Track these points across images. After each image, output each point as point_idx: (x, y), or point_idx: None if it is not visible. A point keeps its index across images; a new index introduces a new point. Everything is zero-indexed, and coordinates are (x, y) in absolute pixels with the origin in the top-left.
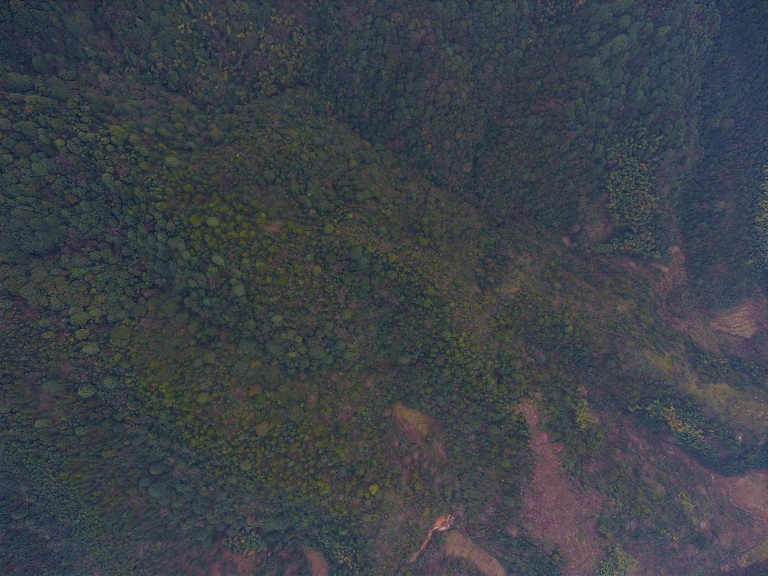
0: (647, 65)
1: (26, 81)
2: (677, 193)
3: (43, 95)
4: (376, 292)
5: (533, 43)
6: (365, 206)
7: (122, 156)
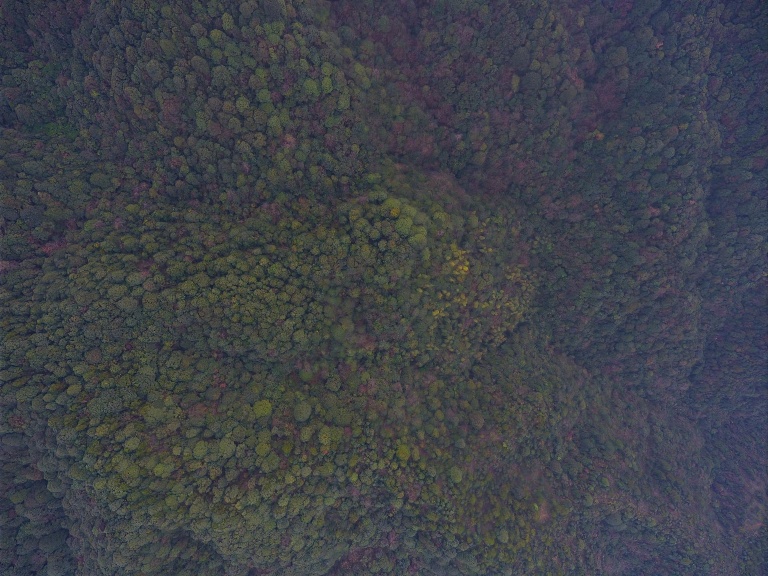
0: None
1: (309, 409)
2: None
3: (326, 421)
4: (624, 544)
5: None
6: (615, 465)
7: (411, 480)
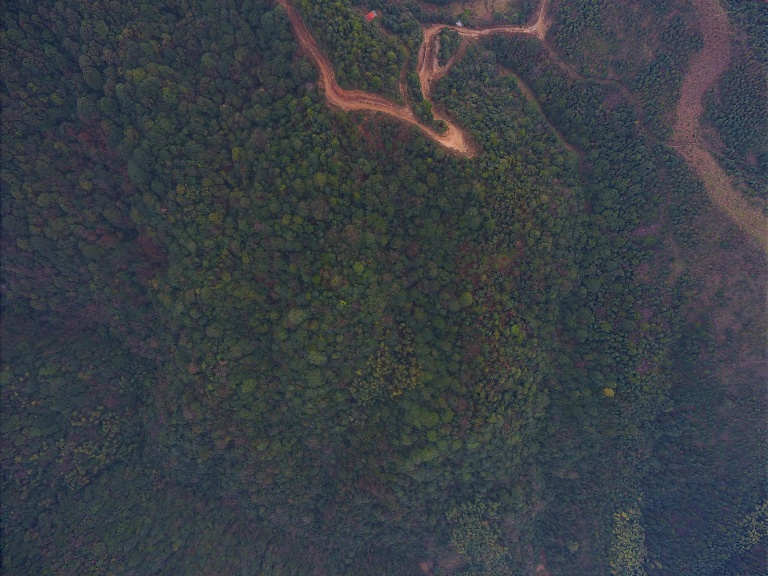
0: (466, 461)
1: None
2: (529, 535)
3: None
4: None
5: (357, 417)
6: None
7: None
